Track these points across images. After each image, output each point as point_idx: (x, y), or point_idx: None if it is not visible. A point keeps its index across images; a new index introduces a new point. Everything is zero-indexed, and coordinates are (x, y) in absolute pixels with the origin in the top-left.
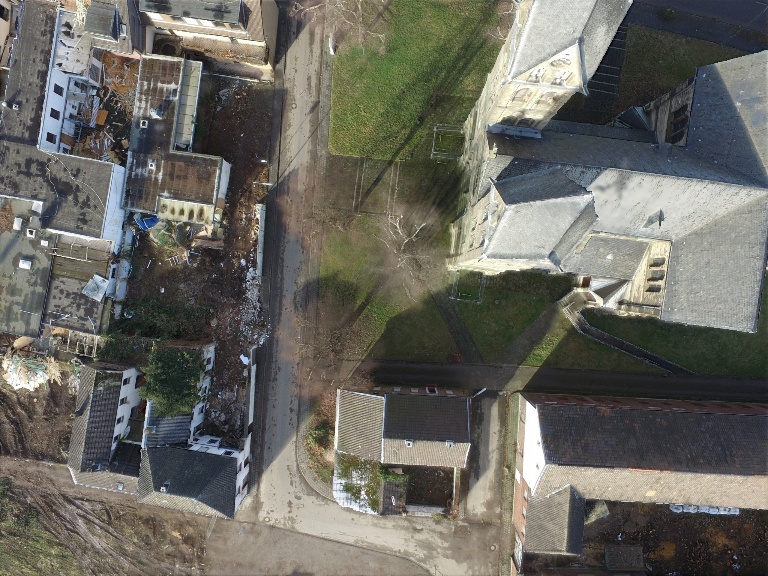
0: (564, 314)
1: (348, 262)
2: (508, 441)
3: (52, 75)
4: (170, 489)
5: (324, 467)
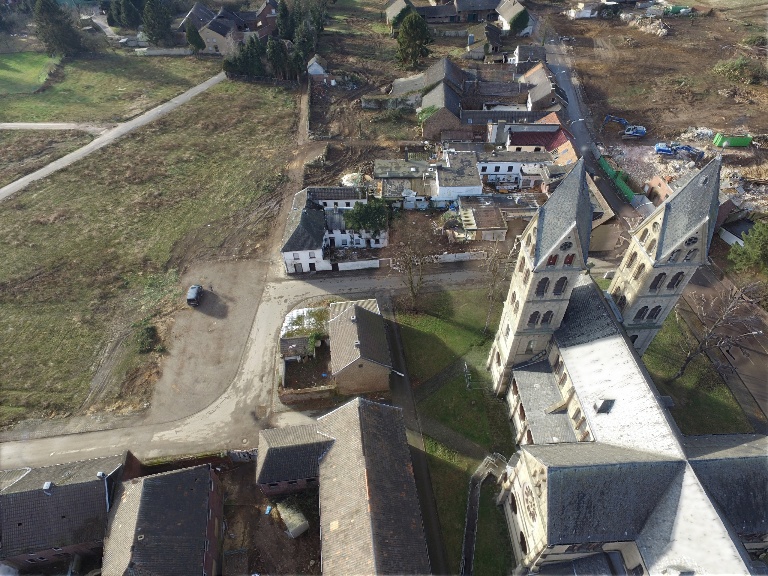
0: None
1: None
2: None
3: (517, 164)
4: (304, 214)
5: None
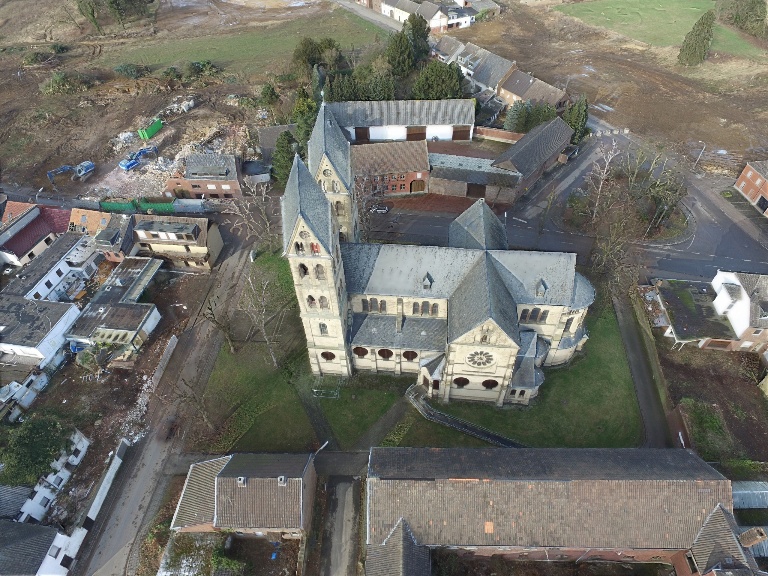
0: (412, 405)
1: (233, 374)
2: (363, 529)
3: (60, 263)
4: None
5: (154, 573)
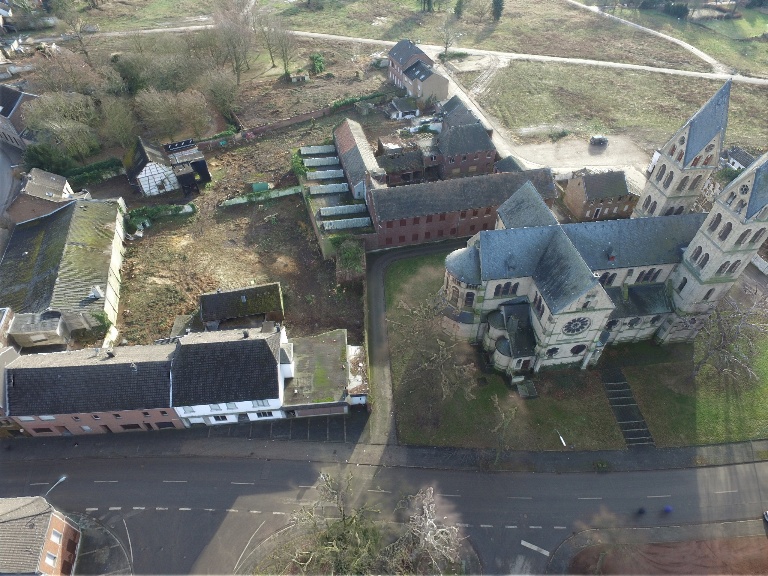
0: None
1: None
2: None
3: None
4: None
5: None
